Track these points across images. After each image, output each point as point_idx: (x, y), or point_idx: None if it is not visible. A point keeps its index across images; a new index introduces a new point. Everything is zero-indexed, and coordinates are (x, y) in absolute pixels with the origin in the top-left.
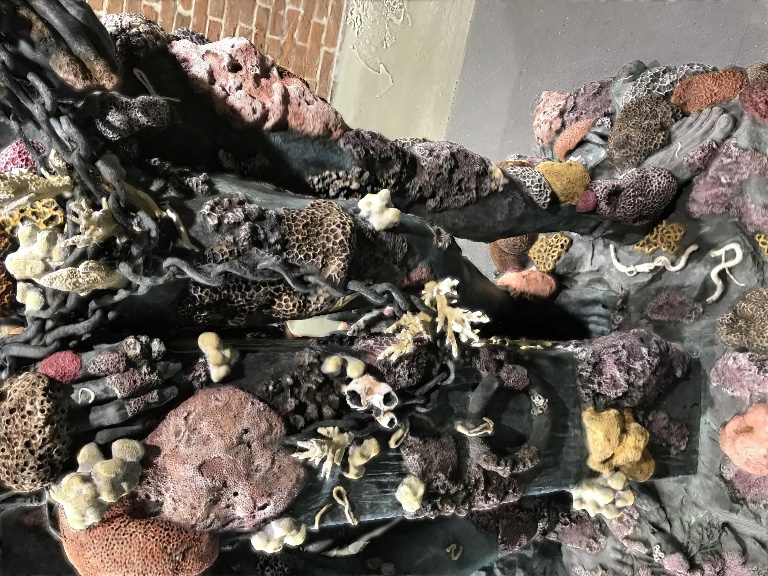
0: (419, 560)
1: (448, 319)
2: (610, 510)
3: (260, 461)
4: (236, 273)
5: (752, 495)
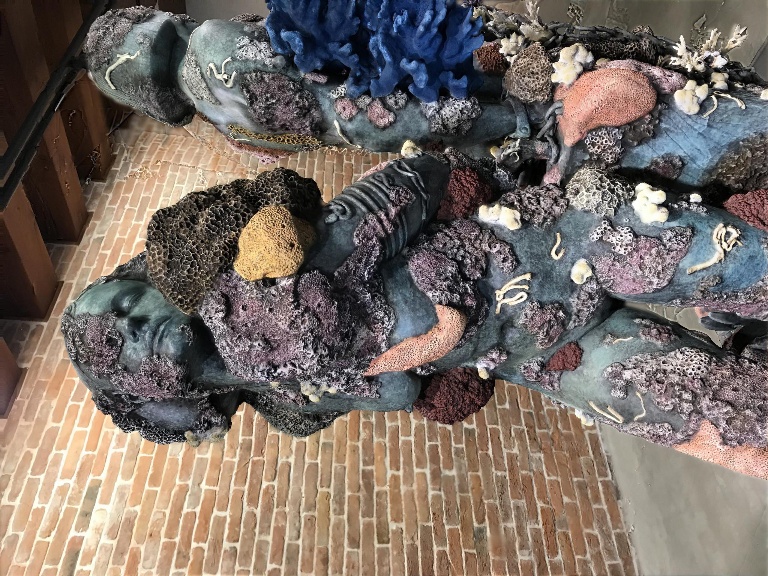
0: None
1: (726, 48)
2: None
3: None
4: (599, 28)
5: None
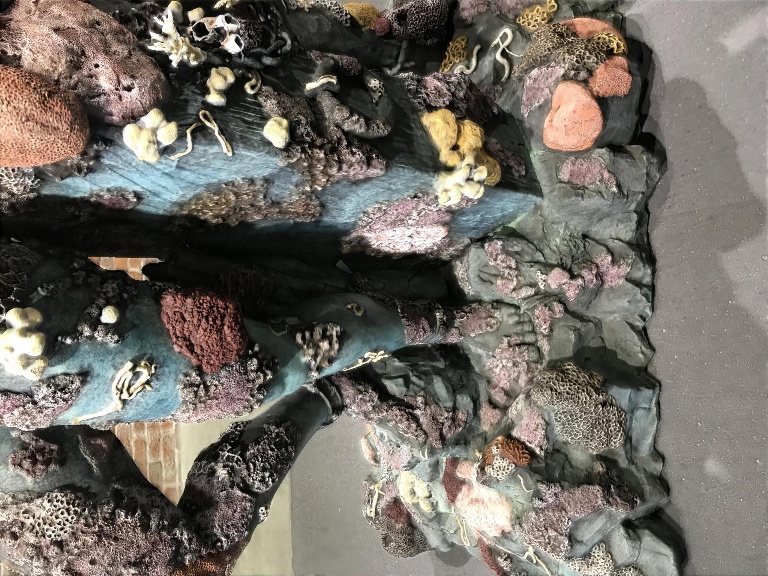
0: (322, 312)
1: None
2: (471, 184)
3: (116, 48)
4: None
5: (588, 180)
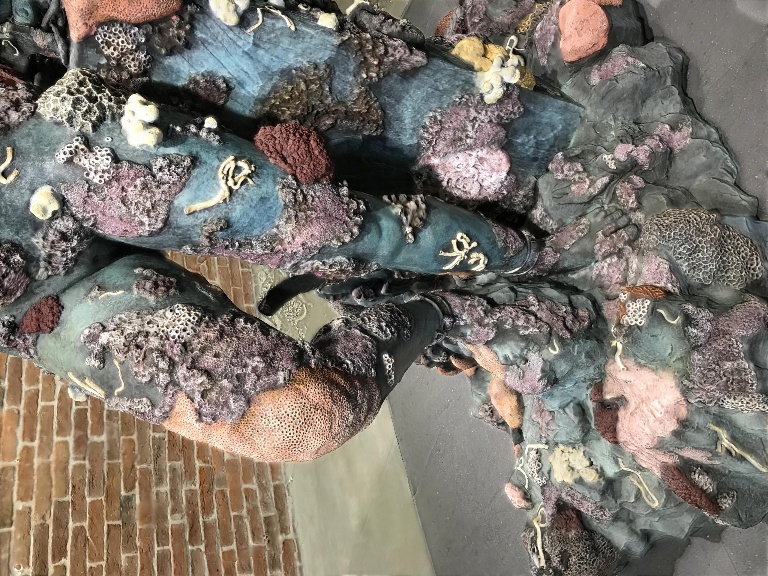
0: None
1: None
2: None
3: None
4: None
5: (616, 71)
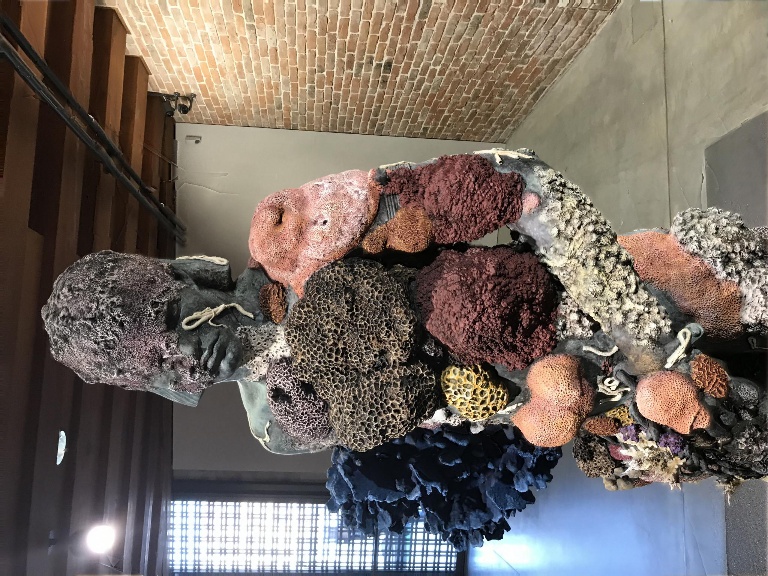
0: None
1: None
2: None
3: None
4: None
5: None
